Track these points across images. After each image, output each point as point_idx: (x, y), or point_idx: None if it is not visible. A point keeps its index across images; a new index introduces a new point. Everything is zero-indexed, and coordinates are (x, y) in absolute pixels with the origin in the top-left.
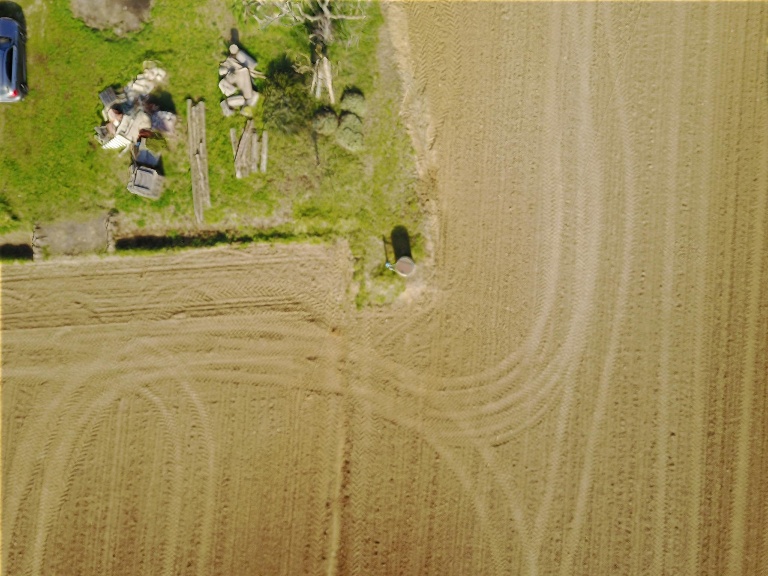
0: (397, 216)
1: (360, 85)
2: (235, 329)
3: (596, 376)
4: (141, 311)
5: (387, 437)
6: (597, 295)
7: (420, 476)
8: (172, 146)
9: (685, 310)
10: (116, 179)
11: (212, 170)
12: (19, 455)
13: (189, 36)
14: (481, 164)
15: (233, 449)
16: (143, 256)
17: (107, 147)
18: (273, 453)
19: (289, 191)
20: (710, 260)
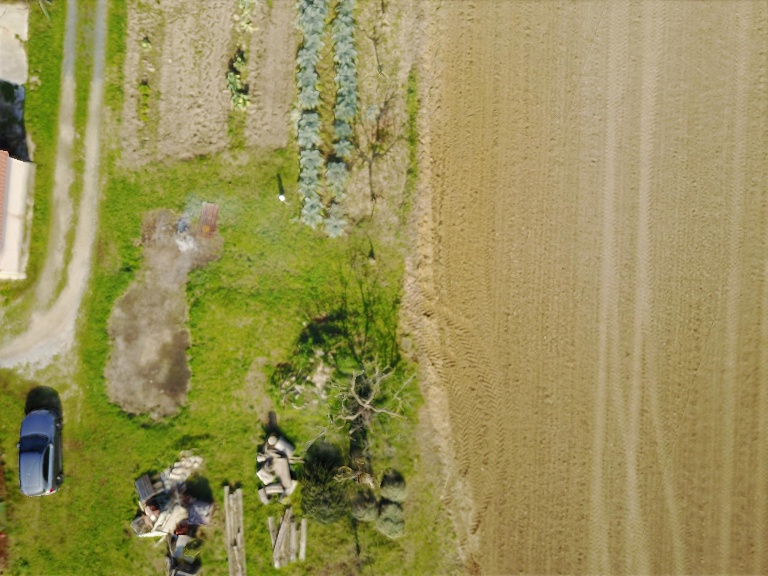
0: None
1: (400, 469)
2: None
3: None
4: None
5: None
6: None
7: None
8: (209, 533)
9: None
10: (152, 568)
11: (250, 559)
12: None
13: (226, 420)
14: (526, 552)
15: None
16: None
17: (143, 536)
18: None
19: None
20: None
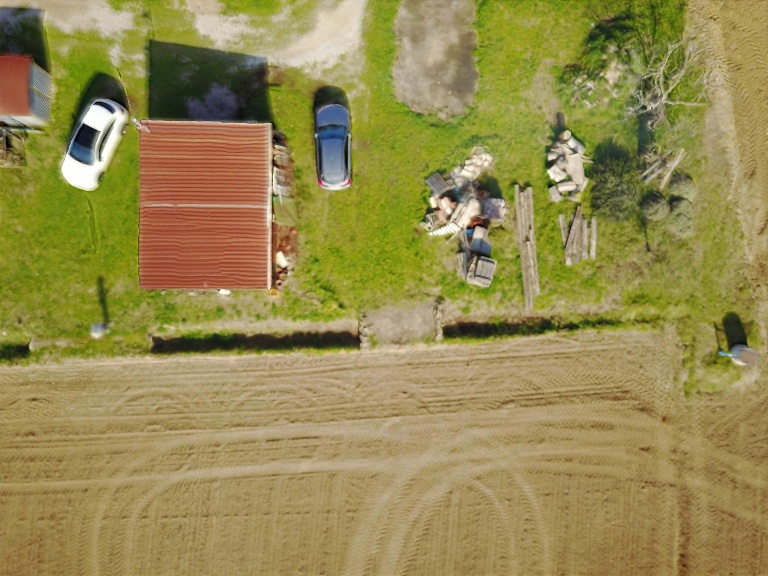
0: (728, 302)
1: None
2: (564, 419)
3: None
4: (469, 401)
5: (725, 530)
6: None
7: (760, 570)
8: None
9: None
10: (442, 266)
11: (540, 256)
12: (350, 550)
13: (515, 120)
14: None
15: (567, 543)
16: (469, 344)
17: (434, 234)
18: (607, 547)
19: (618, 277)
20: None
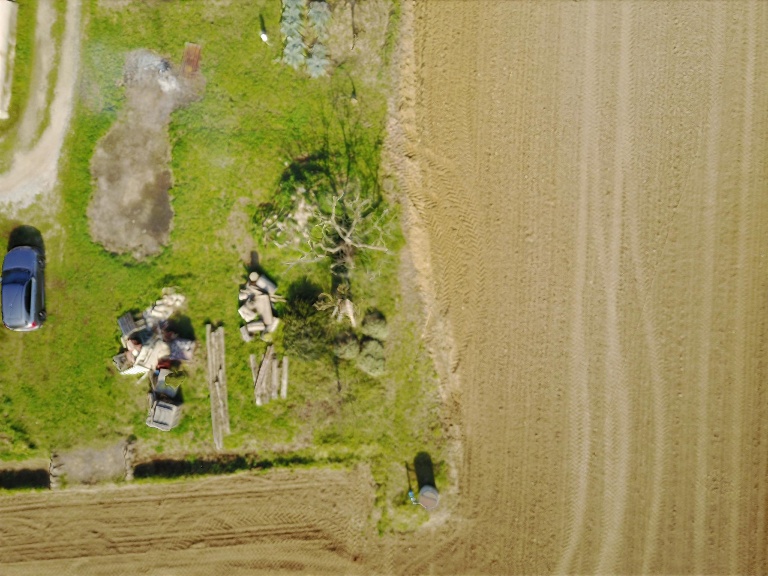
0: (420, 442)
1: (382, 308)
2: (255, 559)
3: None
4: (159, 540)
5: None
6: (627, 529)
7: None
8: (191, 371)
9: (719, 548)
10: (134, 405)
11: (232, 396)
12: None
13: (208, 259)
14: (506, 389)
15: None
16: (161, 483)
17: (125, 373)
18: None
19: (310, 417)
20: (744, 495)
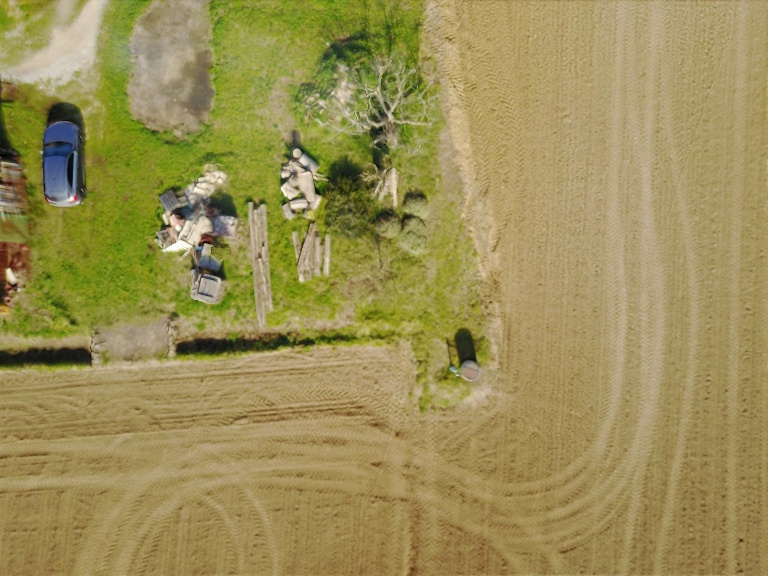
0: (460, 319)
1: (423, 187)
2: (298, 434)
3: (663, 481)
4: (202, 417)
5: (453, 544)
6: (663, 399)
7: None
8: (233, 249)
9: (751, 415)
10: (176, 283)
11: (274, 273)
12: (77, 567)
13: (250, 138)
14: (544, 266)
15: (297, 558)
16: (204, 360)
17: (167, 251)
18: (337, 561)
19: (352, 294)
20: None
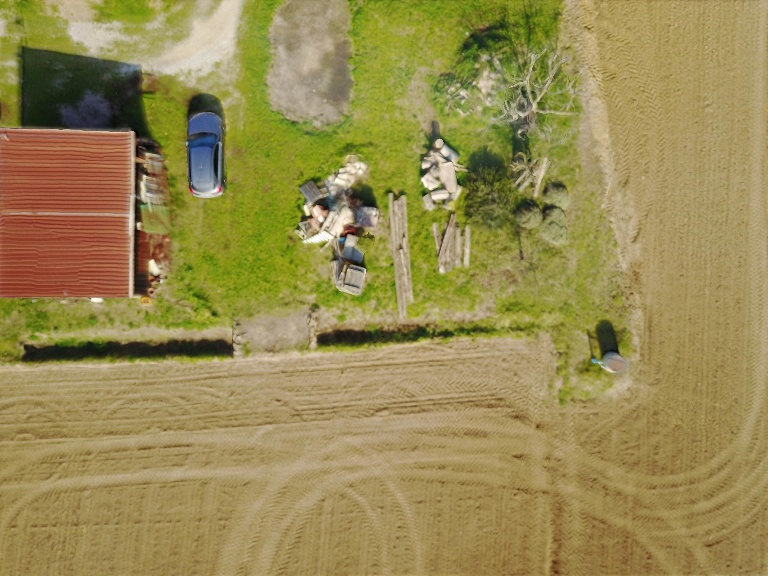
0: (601, 310)
1: (562, 178)
2: (438, 426)
3: None
4: (343, 408)
5: (596, 537)
6: None
7: None
8: None
9: None
10: (317, 274)
11: (414, 264)
12: (221, 559)
13: (390, 129)
14: (686, 257)
15: (439, 550)
16: (344, 352)
17: (308, 242)
18: (479, 554)
19: (492, 285)
20: None
